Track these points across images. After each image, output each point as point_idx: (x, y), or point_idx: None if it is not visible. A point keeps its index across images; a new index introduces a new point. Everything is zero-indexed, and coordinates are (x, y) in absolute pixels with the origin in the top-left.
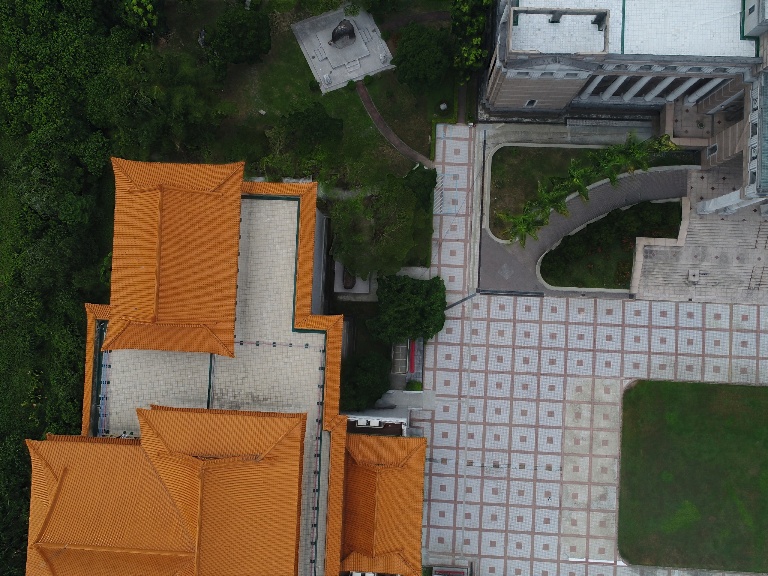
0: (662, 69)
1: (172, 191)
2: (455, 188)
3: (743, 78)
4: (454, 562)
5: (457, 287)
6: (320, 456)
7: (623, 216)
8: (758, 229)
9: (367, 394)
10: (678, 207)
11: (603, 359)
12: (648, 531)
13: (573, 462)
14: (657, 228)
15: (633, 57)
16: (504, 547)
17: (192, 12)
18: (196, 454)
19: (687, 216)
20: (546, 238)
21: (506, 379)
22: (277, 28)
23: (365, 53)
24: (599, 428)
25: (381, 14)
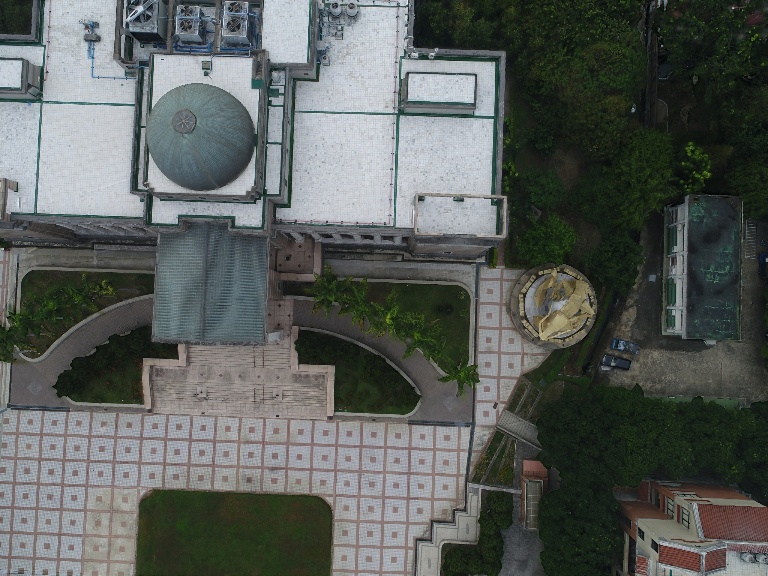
0: None
1: None
2: None
3: None
4: None
5: None
6: None
7: None
8: (253, 350)
9: None
10: None
11: (122, 470)
12: None
13: (92, 568)
14: None
15: (37, 218)
16: None
17: None
18: None
19: None
20: (70, 357)
21: (32, 490)
22: None
23: None
24: (117, 535)
25: None
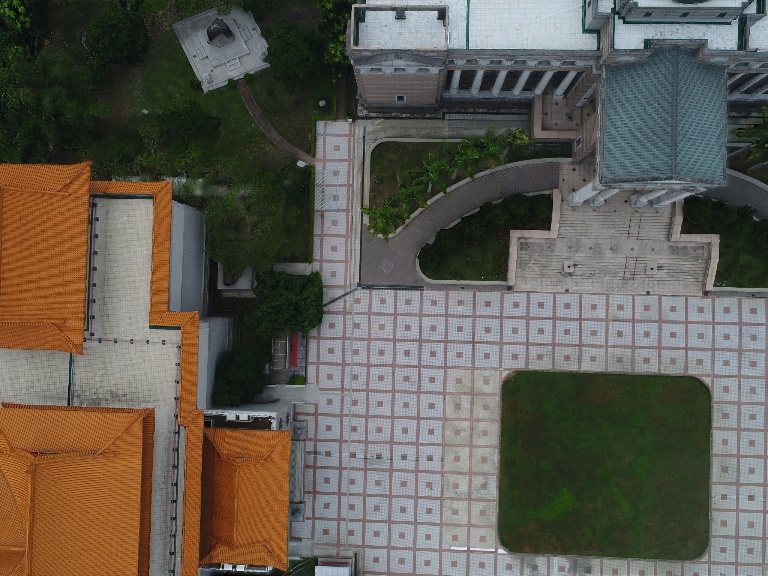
0: (512, 63)
1: (13, 192)
2: (336, 184)
3: (591, 71)
4: (339, 553)
5: (339, 282)
6: (178, 450)
7: (492, 209)
8: (629, 220)
9: (242, 389)
10: (547, 199)
11: (482, 351)
12: (527, 519)
13: (454, 453)
14: (530, 220)
15: (476, 52)
16: (387, 537)
17: (72, 13)
18: (36, 450)
19: (558, 208)
20: (425, 232)
21: (388, 372)
22: (159, 28)
23: (245, 51)
24: (479, 419)
25: (261, 12)
